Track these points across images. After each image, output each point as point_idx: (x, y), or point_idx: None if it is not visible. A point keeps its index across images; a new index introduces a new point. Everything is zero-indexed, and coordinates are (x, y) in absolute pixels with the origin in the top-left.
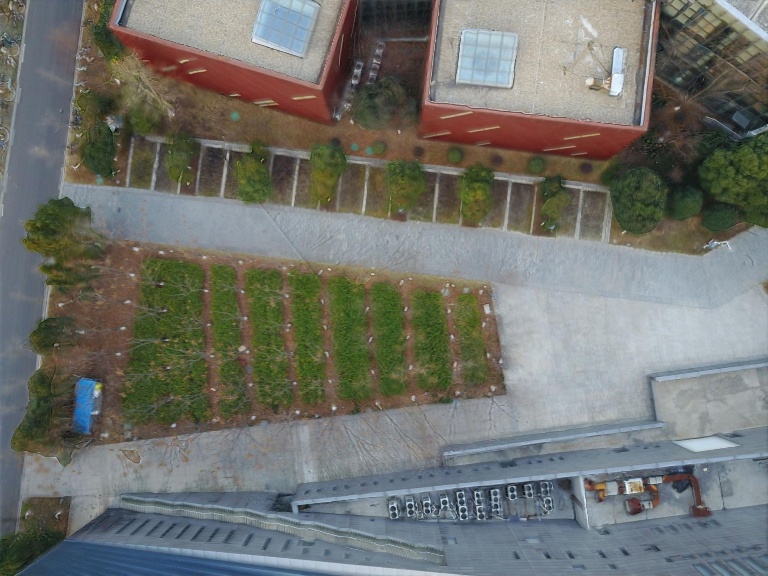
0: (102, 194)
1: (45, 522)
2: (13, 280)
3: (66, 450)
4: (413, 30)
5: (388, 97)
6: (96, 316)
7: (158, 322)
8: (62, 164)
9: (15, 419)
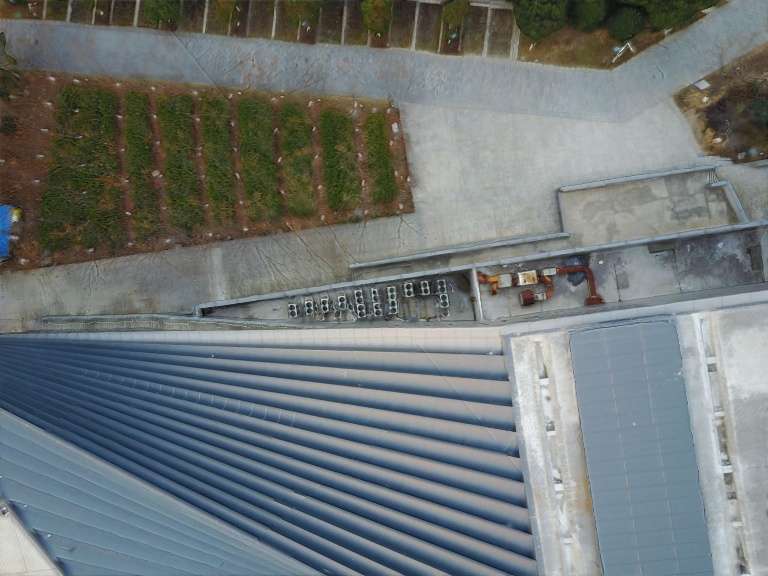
0: (20, 27)
1: None
2: None
3: None
4: None
5: None
6: (16, 145)
7: (74, 147)
8: None
9: None
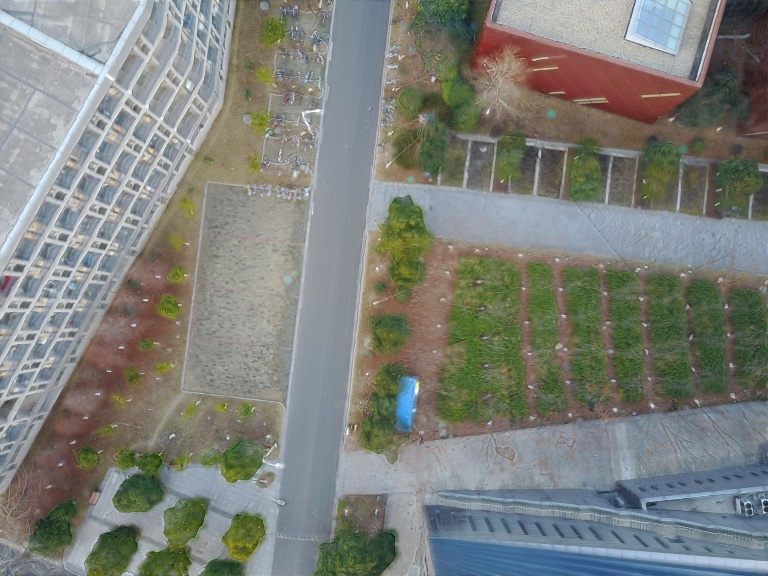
0: (414, 192)
1: (362, 519)
2: (325, 278)
3: (395, 447)
4: (740, 27)
5: (725, 94)
6: (410, 314)
7: (477, 320)
8: (371, 162)
9: (330, 416)
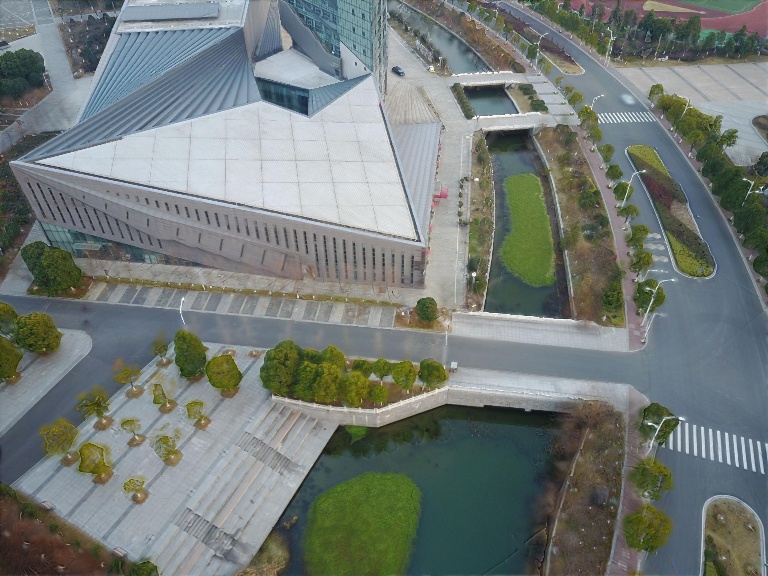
0: None
1: None
2: None
3: None
4: None
5: None
6: None
7: None
8: None
9: None
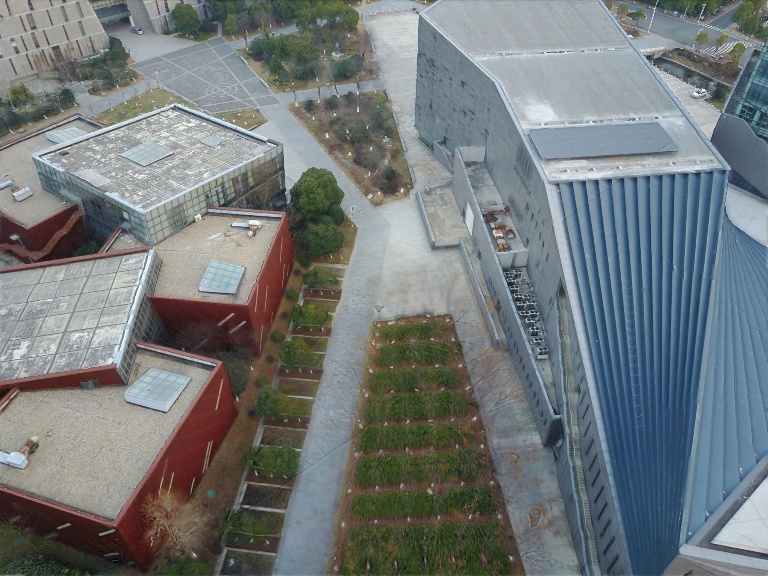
0: None
1: None
2: None
3: None
4: None
5: (227, 359)
6: None
7: (407, 567)
8: None
9: None
